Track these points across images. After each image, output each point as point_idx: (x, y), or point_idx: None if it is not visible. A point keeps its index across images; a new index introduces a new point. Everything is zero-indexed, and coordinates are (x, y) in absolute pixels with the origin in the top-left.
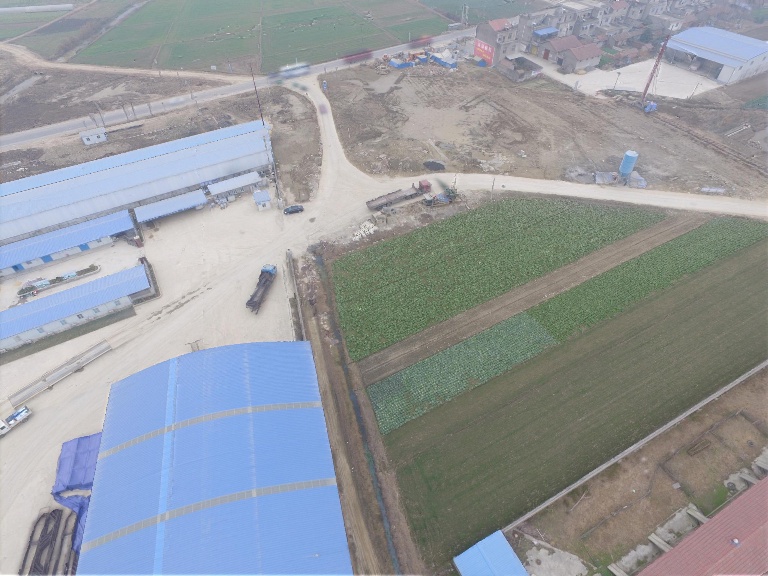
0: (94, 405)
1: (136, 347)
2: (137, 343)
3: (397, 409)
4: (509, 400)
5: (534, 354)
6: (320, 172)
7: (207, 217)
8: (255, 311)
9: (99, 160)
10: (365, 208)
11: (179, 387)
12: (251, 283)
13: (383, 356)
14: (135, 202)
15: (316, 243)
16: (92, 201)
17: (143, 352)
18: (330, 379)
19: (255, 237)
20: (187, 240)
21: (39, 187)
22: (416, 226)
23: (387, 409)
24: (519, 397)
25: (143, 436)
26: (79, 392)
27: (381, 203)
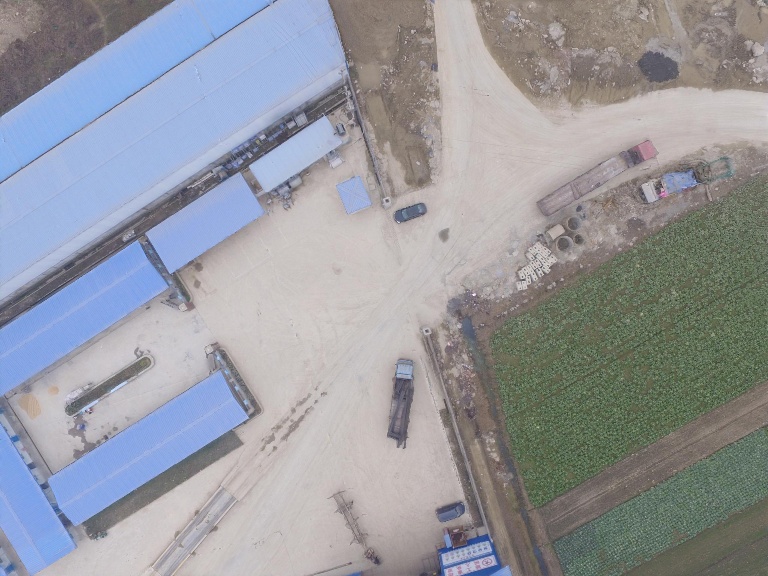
0: (252, 573)
1: (265, 495)
2: (264, 489)
3: (590, 572)
4: (717, 559)
5: (760, 498)
6: (439, 92)
7: (268, 232)
8: (402, 445)
9: (21, 109)
10: (531, 203)
11: None
12: (379, 382)
13: (571, 500)
14: (138, 210)
15: (459, 294)
16: (74, 239)
17: (277, 501)
18: (510, 533)
19: (360, 281)
20: (256, 291)
21: None
22: (617, 246)
23: (579, 572)
24: (729, 555)
25: None
26: (227, 557)
27: (564, 206)
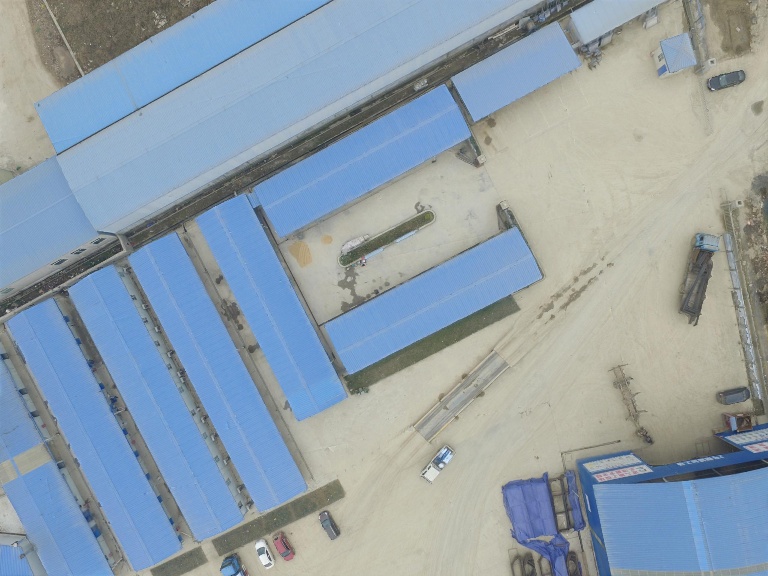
0: (516, 442)
1: (537, 363)
2: (537, 357)
3: None
4: None
5: None
6: None
7: (570, 91)
8: (694, 322)
9: None
10: None
11: (707, 526)
12: (671, 257)
13: None
14: (443, 55)
15: (767, 171)
16: (389, 73)
17: (549, 372)
18: None
19: (662, 150)
20: (550, 152)
21: (280, 32)
22: None
23: None
24: None
25: (673, 573)
26: (492, 424)
27: None
